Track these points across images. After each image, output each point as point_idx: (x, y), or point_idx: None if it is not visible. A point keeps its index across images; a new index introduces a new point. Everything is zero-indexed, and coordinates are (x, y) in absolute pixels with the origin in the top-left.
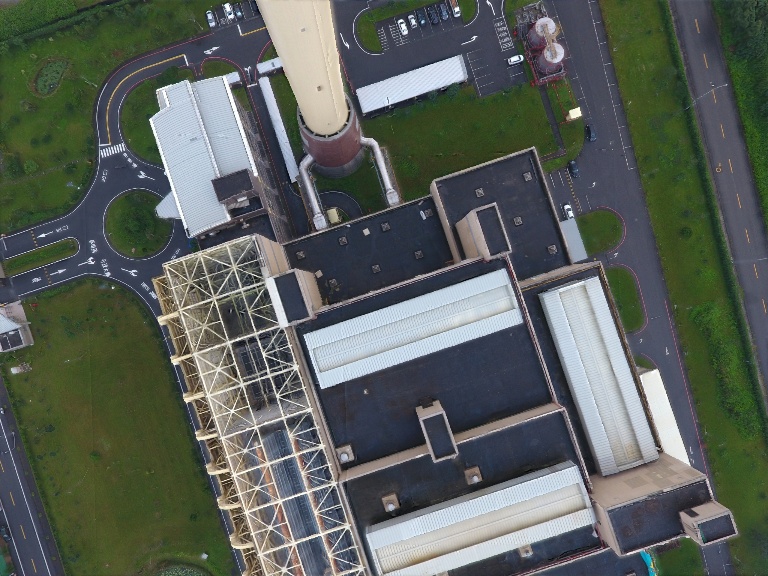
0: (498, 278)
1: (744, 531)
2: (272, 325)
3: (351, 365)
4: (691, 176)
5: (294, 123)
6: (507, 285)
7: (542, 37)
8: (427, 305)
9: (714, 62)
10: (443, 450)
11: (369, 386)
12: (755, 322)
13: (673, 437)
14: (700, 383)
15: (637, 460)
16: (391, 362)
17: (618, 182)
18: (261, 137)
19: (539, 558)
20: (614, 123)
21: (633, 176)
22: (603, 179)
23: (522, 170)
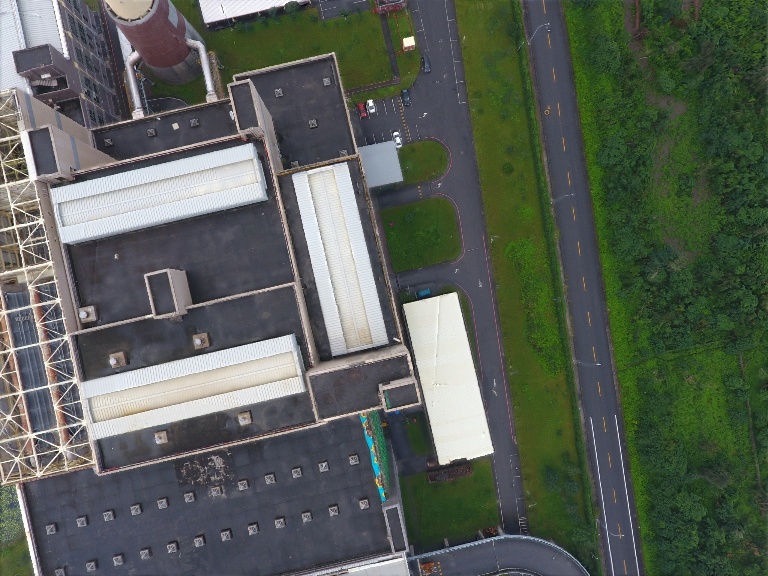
0: (244, 152)
1: (538, 466)
2: (23, 178)
3: (93, 222)
4: (519, 115)
5: None
6: (253, 159)
7: None
8: (173, 171)
9: (552, 8)
10: (165, 308)
11: (120, 251)
12: (569, 263)
13: (464, 360)
14: (509, 317)
15: (367, 344)
16: (132, 223)
17: (448, 114)
18: (106, 38)
19: (258, 428)
20: (450, 57)
21: (463, 110)
22: (434, 110)
23: (323, 75)
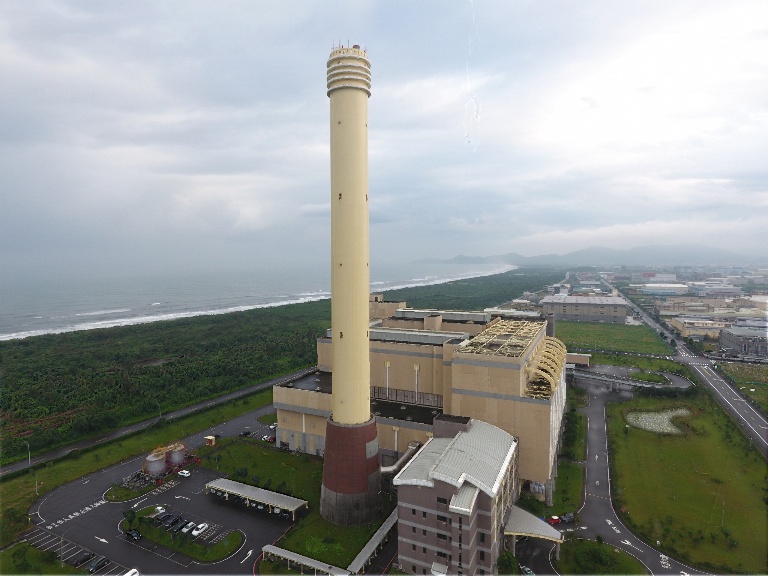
0: None
1: None
2: None
3: None
4: None
5: (364, 538)
6: None
7: (166, 455)
8: None
9: None
10: None
11: None
12: None
13: None
14: None
15: (374, 320)
16: None
17: None
18: None
19: None
20: None
21: None
22: None
23: None
